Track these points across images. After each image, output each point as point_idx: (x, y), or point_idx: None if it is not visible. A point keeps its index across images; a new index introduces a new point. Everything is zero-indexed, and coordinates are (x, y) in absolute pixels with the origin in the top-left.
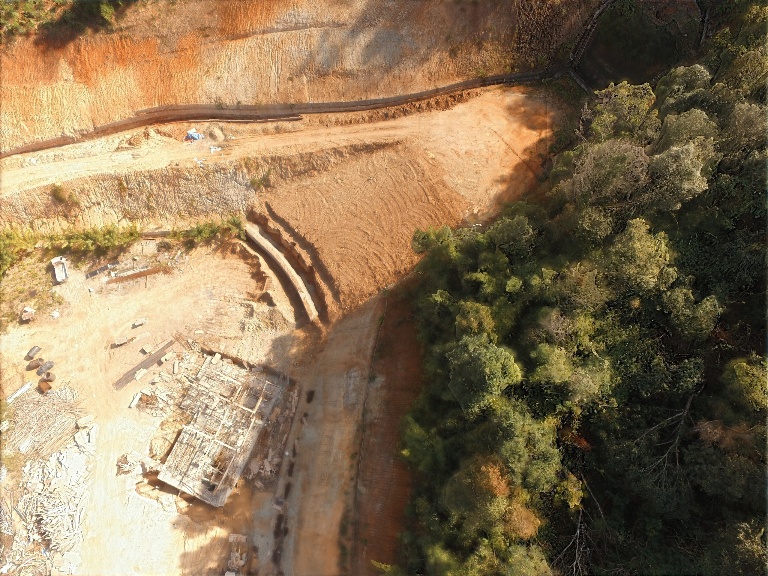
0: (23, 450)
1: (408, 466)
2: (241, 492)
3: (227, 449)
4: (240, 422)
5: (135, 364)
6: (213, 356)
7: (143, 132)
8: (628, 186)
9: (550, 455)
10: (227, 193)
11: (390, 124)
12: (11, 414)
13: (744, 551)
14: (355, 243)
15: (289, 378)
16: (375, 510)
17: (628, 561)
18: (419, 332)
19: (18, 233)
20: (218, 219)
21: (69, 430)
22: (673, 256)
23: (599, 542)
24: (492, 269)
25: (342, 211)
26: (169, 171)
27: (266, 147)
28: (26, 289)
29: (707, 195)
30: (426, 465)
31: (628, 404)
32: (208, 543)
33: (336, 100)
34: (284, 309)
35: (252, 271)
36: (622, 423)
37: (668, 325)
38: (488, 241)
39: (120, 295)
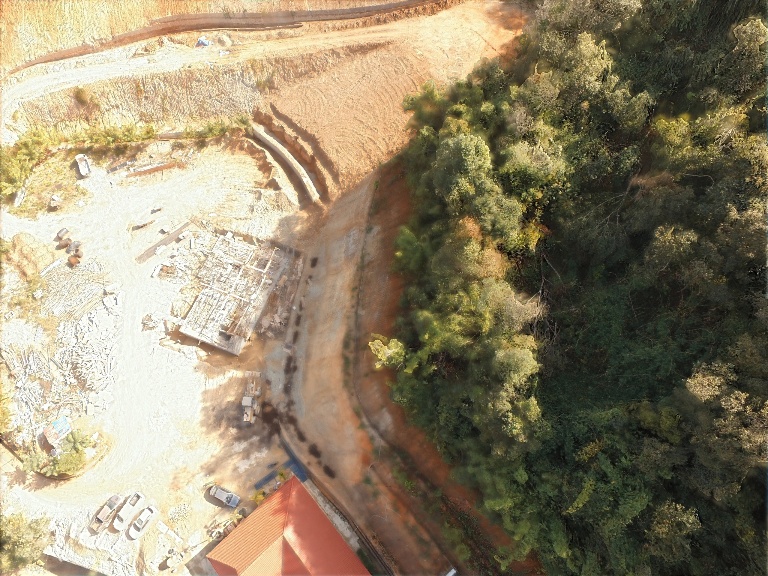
0: (57, 313)
1: (401, 272)
2: (254, 344)
3: (241, 308)
4: (251, 287)
5: (155, 242)
6: (225, 235)
7: (157, 40)
8: (578, 10)
9: (514, 208)
10: (235, 95)
11: (382, 28)
12: (44, 285)
13: (659, 244)
14: (352, 131)
15: (295, 250)
16: (373, 319)
17: (579, 303)
18: (409, 179)
19: (44, 132)
20: (227, 120)
21: (98, 295)
22: (616, 71)
23: (557, 298)
24: (470, 101)
25: (340, 105)
26: (182, 73)
27: (270, 50)
28: (52, 183)
29: (642, 15)
30: (416, 261)
31: (581, 193)
32: (226, 382)
33: (333, 7)
34: (289, 192)
35: (259, 164)
36: (576, 210)
37: (611, 122)
38: (466, 82)
39: (139, 186)
